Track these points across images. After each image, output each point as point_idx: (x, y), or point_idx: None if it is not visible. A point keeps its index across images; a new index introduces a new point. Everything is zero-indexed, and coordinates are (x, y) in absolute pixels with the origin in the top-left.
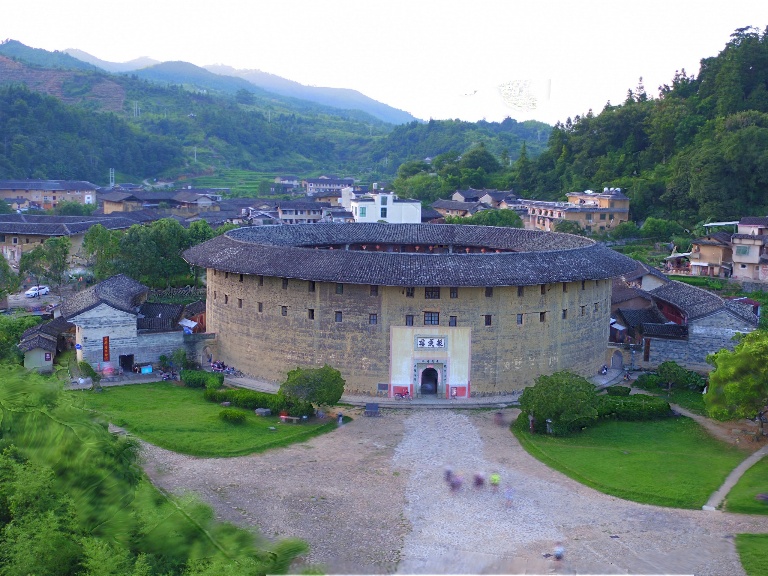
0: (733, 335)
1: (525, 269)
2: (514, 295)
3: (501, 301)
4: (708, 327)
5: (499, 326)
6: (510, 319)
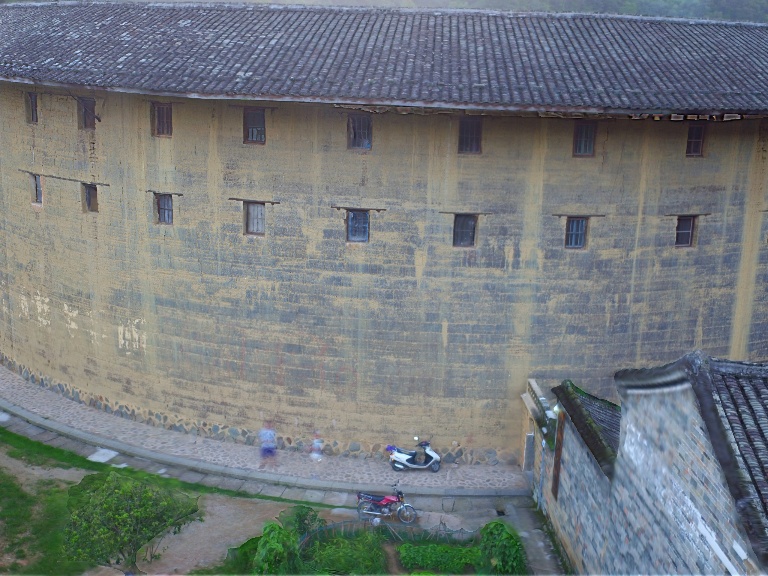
0: (698, 551)
1: (8, 39)
2: (20, 117)
3: (2, 128)
4: (650, 448)
5: (5, 195)
6: (19, 182)
